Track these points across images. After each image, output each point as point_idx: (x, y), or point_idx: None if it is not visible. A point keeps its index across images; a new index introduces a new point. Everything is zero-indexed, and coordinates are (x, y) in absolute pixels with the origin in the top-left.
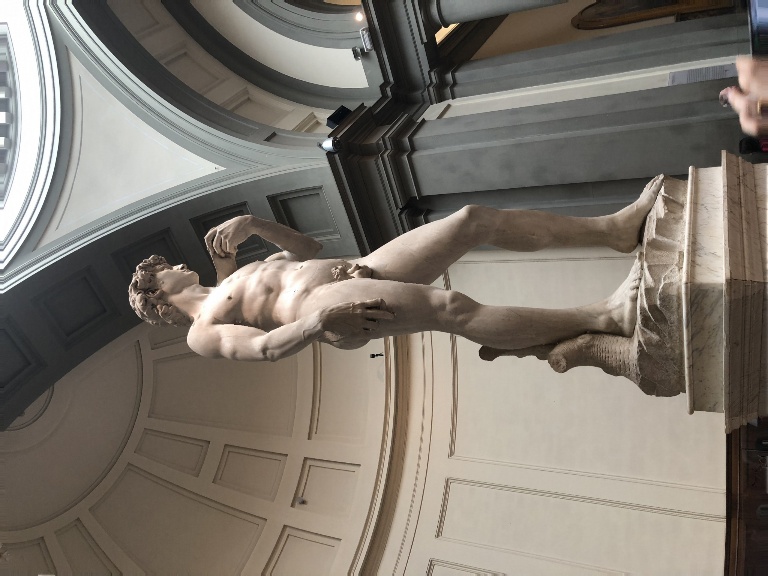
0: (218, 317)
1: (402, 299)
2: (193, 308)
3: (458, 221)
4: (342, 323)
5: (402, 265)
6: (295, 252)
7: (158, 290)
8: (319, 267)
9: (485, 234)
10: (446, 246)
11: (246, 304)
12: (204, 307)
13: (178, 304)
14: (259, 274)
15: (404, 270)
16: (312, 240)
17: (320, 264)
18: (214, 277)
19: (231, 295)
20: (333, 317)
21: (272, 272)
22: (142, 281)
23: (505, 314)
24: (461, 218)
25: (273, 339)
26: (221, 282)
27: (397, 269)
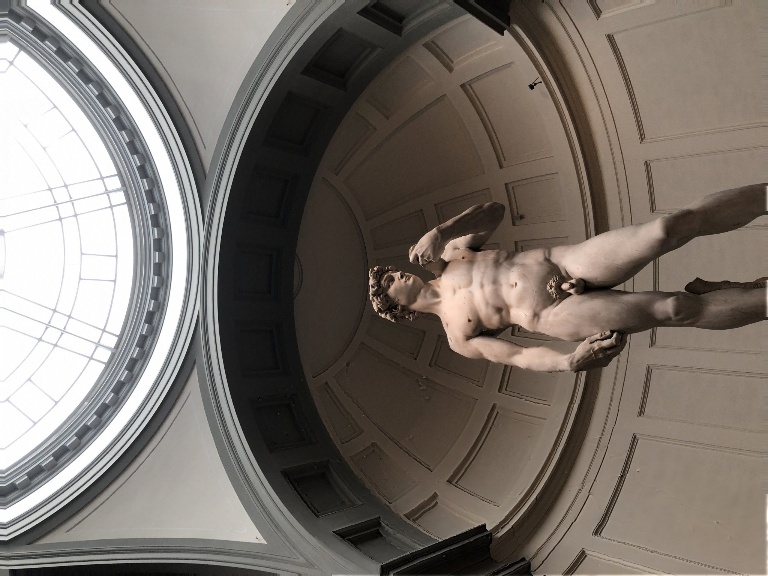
0: (468, 335)
1: (629, 323)
2: (434, 310)
3: (657, 242)
4: (591, 367)
5: (612, 276)
6: (486, 230)
7: (398, 306)
8: (535, 289)
9: (687, 241)
10: (651, 258)
11: (485, 322)
12: (445, 315)
13: (420, 310)
14: (482, 295)
15: (615, 278)
16: (494, 209)
17: (533, 284)
18: (431, 274)
19: (469, 318)
20: (582, 366)
21: (492, 292)
22: (383, 306)
23: (730, 315)
24: (659, 239)
25: (533, 368)
26: (438, 274)
27: (608, 279)
